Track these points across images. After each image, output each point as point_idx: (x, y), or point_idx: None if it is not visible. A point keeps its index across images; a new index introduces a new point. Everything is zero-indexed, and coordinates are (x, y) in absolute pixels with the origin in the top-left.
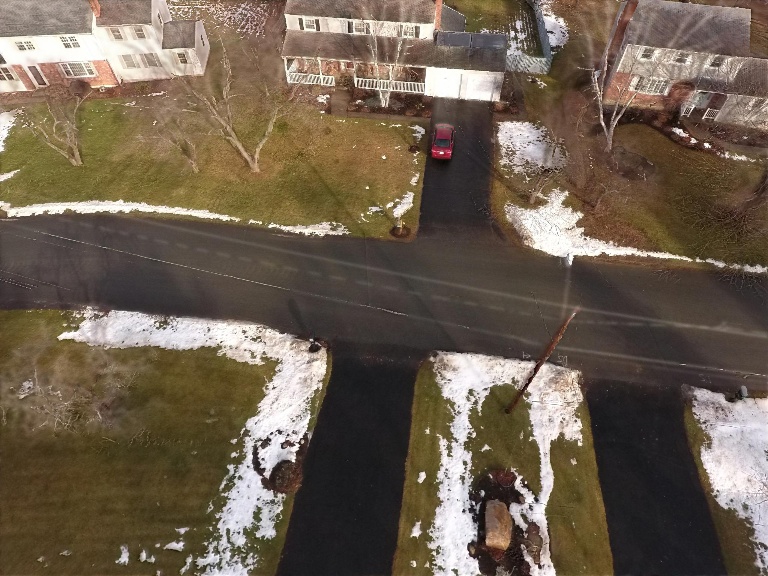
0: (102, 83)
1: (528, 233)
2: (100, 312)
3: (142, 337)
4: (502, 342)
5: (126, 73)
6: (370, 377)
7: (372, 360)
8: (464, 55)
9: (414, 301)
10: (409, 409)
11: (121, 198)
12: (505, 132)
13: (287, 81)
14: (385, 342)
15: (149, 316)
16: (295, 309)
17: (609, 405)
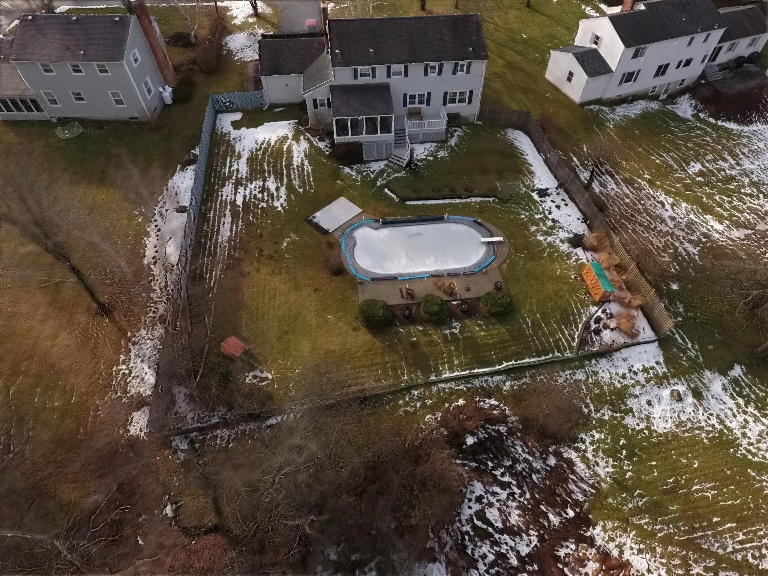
0: None
1: None
2: None
3: None
4: None
5: None
6: None
7: None
8: None
9: None
10: None
11: None
12: None
13: None
14: None
15: None
16: None
17: None
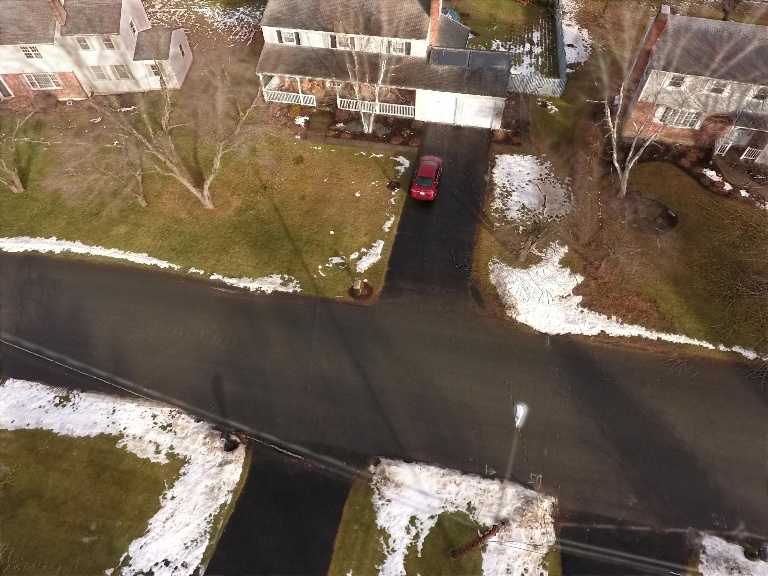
0: (70, 96)
1: (512, 301)
2: None
3: (35, 416)
4: (462, 450)
5: (97, 85)
6: (292, 489)
7: (298, 465)
8: (460, 76)
9: (362, 386)
10: (331, 540)
11: (55, 235)
12: (502, 167)
13: (264, 99)
14: (318, 441)
15: (50, 388)
16: (219, 388)
17: (588, 553)
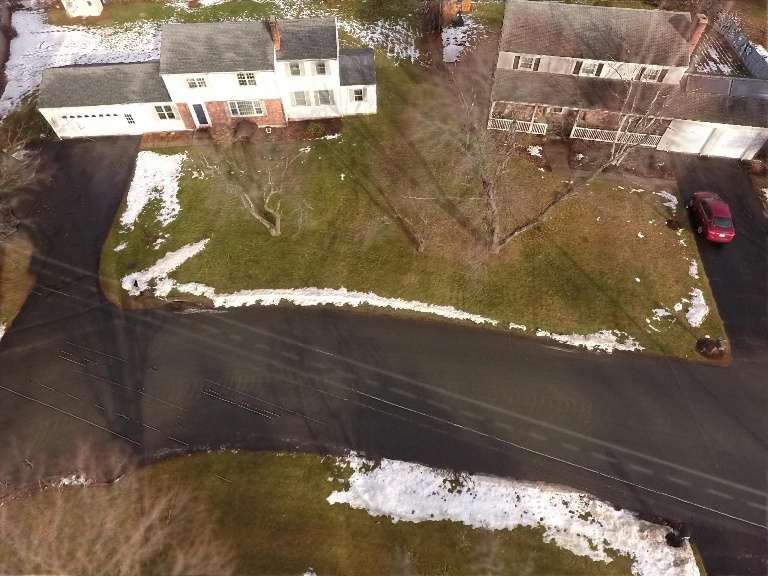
0: (268, 123)
1: None
2: (369, 460)
3: (436, 505)
4: None
5: (293, 111)
6: None
7: (756, 562)
8: (721, 105)
9: None
10: None
11: (342, 285)
12: None
13: (487, 127)
14: (762, 531)
15: (434, 470)
16: (619, 468)
17: None
